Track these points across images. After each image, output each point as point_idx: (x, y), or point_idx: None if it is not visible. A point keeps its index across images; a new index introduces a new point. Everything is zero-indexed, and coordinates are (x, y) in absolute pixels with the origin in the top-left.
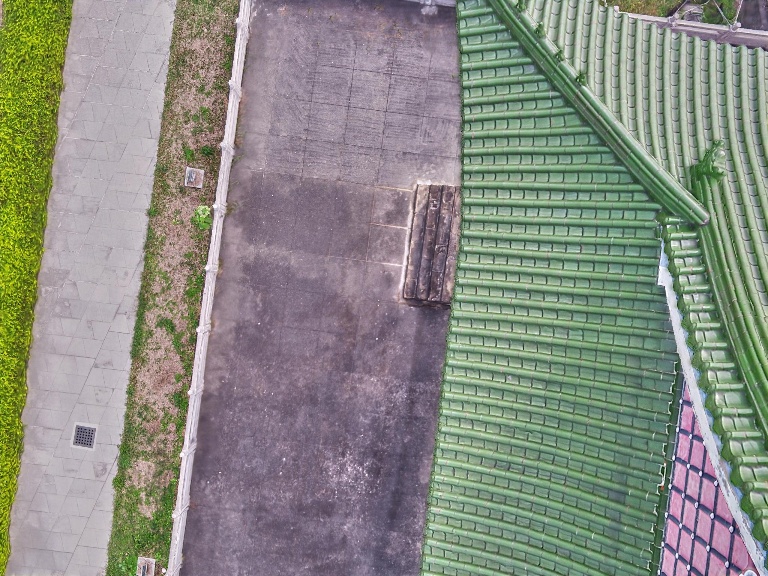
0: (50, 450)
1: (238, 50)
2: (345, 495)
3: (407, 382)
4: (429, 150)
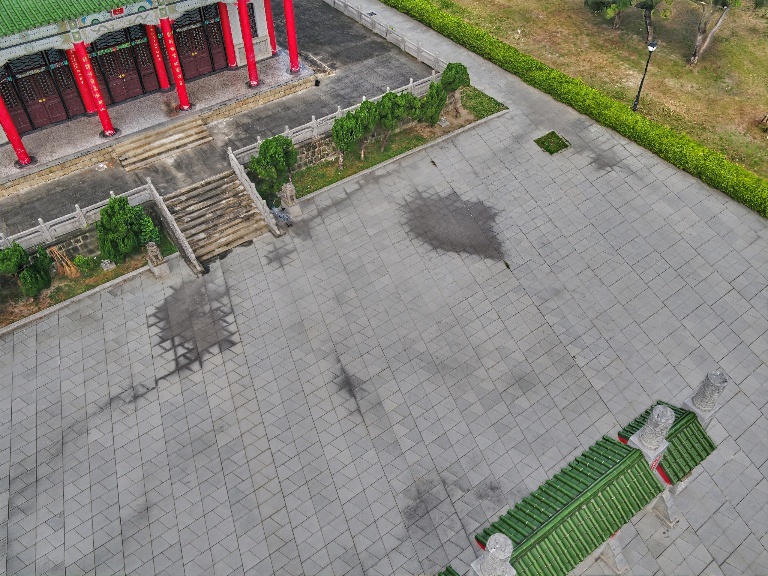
0: (378, 8)
1: (430, 53)
2: (274, 19)
3: (282, 42)
4: (340, 81)
